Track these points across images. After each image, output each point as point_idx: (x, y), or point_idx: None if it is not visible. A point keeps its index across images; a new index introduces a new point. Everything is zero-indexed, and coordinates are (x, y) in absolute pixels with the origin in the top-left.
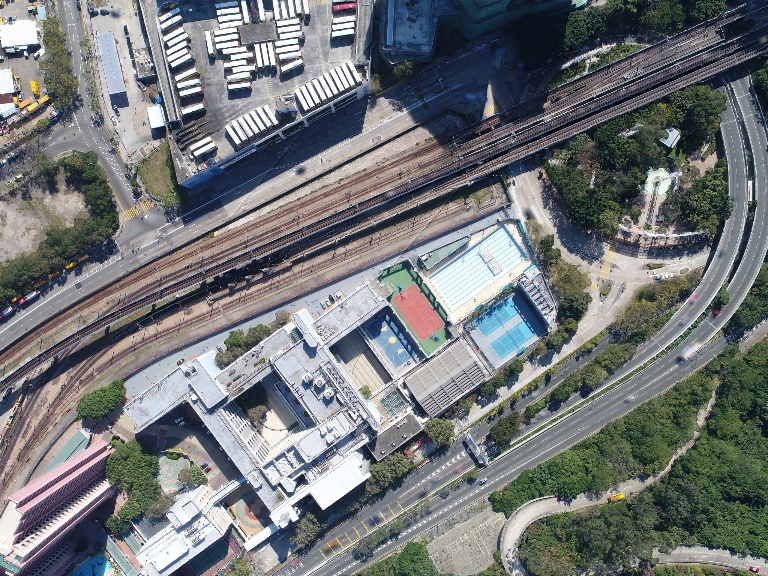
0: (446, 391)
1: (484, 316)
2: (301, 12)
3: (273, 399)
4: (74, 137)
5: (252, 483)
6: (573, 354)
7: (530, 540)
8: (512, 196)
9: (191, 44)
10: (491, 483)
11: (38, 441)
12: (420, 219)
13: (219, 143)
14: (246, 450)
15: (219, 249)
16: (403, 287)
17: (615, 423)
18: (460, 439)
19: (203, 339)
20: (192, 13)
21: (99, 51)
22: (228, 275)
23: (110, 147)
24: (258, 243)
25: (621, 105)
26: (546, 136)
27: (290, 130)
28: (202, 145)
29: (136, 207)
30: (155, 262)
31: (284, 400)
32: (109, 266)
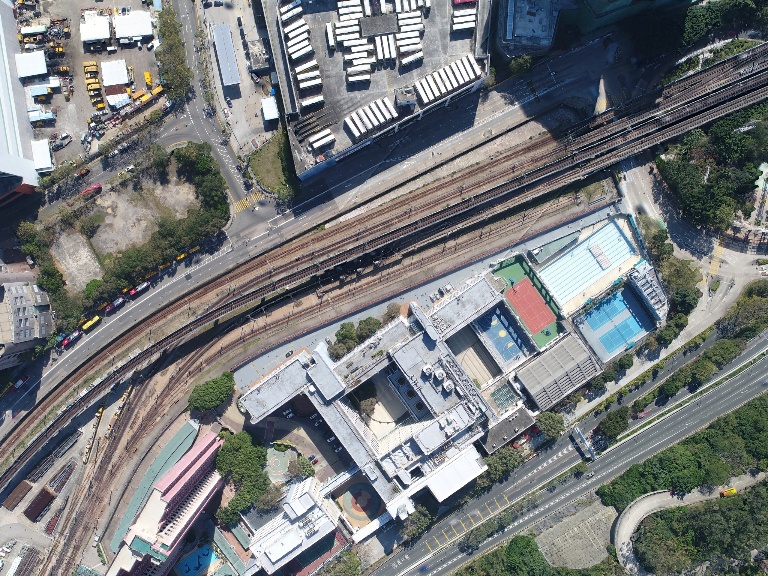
0: (559, 385)
1: (593, 310)
2: (422, 5)
3: (381, 392)
4: (186, 128)
5: (369, 475)
6: (681, 349)
7: (645, 534)
8: (623, 191)
9: (310, 36)
10: (598, 477)
11: (146, 432)
12: (530, 213)
13: (337, 135)
14: (362, 442)
15: (330, 241)
16: (515, 281)
17: (726, 418)
18: (567, 433)
19: (312, 331)
20: (312, 5)
21: (214, 42)
22: (340, 267)
23: (222, 139)
24: (369, 236)
25: (736, 100)
26: (660, 131)
27: (406, 123)
28: (321, 137)
29: (247, 199)
30: (266, 254)
31: (397, 393)
32: (219, 258)
